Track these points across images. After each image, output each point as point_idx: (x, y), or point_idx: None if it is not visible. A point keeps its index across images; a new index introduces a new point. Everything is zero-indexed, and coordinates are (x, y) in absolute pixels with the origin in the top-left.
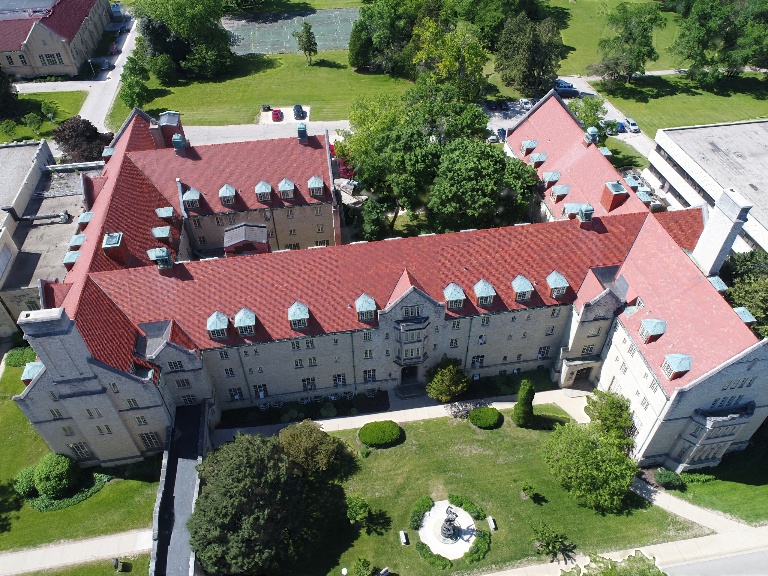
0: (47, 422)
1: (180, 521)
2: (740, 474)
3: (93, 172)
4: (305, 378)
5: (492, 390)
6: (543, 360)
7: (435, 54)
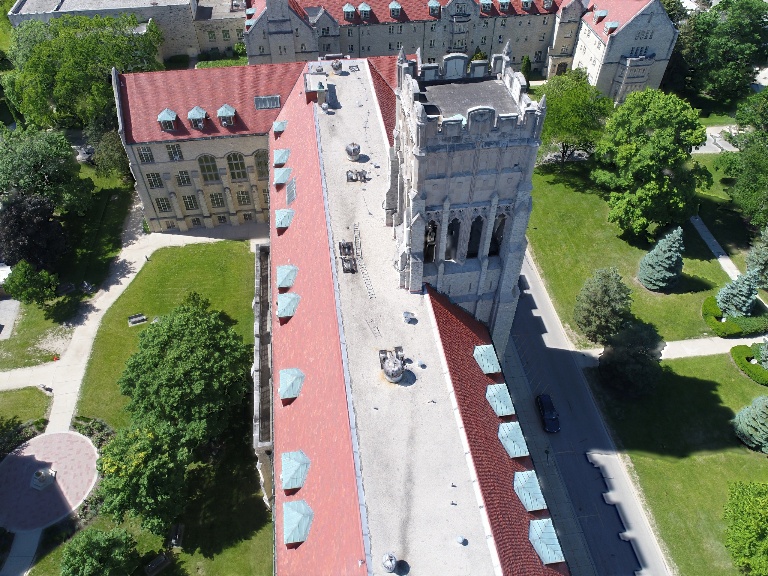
0: (256, 57)
1: None
2: None
3: None
4: None
5: None
6: (537, 63)
7: None
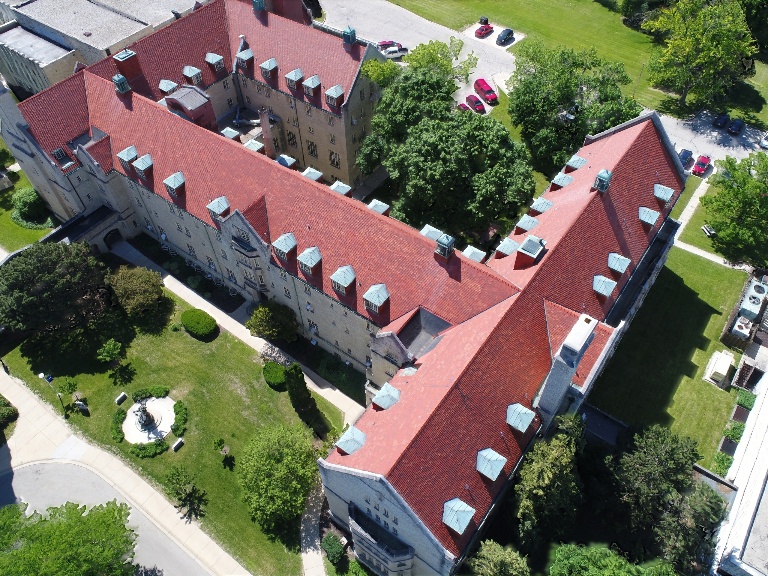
0: None
1: None
2: None
3: None
4: None
5: (312, 361)
6: None
7: (665, 26)
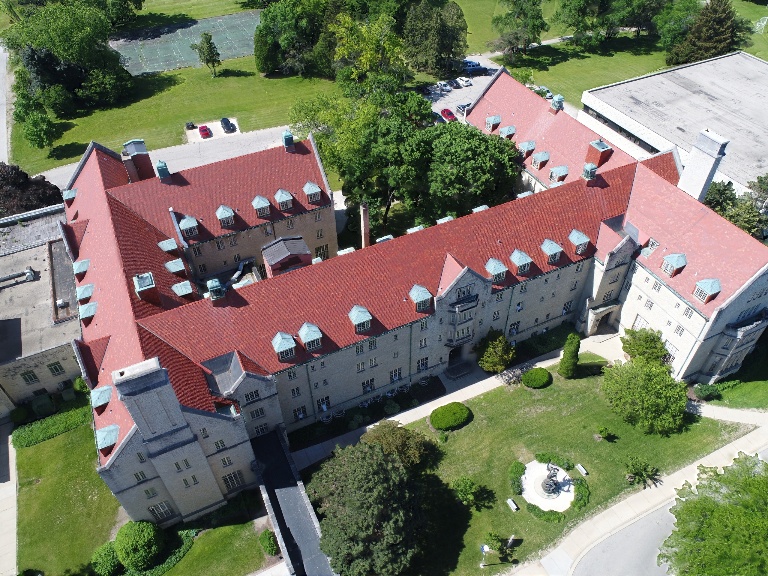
0: (130, 488)
1: (306, 549)
2: (756, 374)
3: (39, 221)
4: (365, 381)
5: (531, 352)
6: (567, 315)
7: (358, 48)
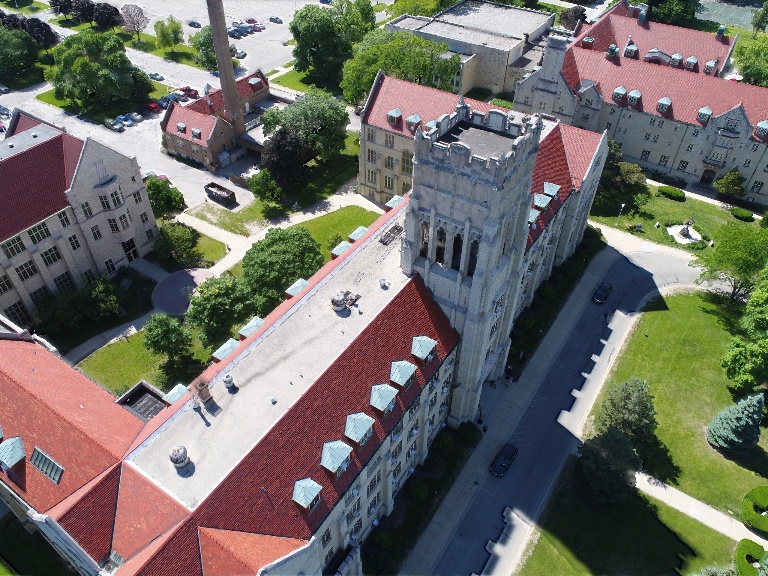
0: (520, 104)
1: None
2: None
3: None
4: (645, 150)
5: (757, 209)
6: None
7: None
